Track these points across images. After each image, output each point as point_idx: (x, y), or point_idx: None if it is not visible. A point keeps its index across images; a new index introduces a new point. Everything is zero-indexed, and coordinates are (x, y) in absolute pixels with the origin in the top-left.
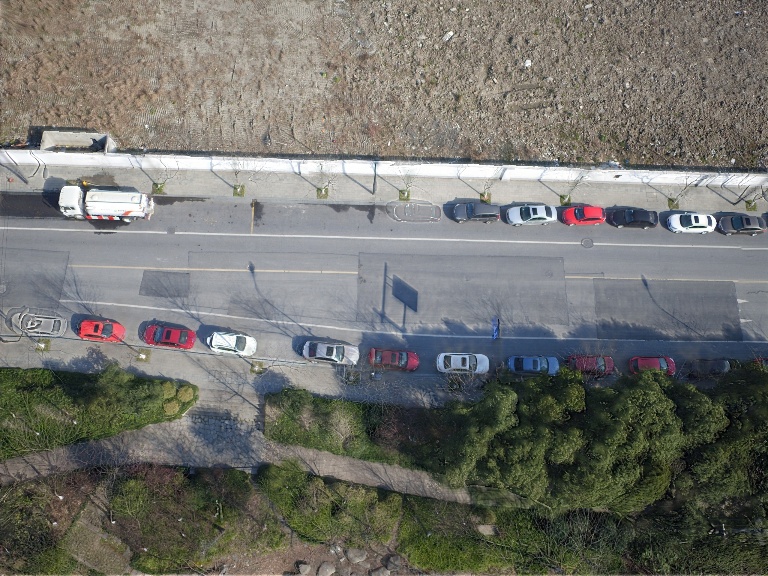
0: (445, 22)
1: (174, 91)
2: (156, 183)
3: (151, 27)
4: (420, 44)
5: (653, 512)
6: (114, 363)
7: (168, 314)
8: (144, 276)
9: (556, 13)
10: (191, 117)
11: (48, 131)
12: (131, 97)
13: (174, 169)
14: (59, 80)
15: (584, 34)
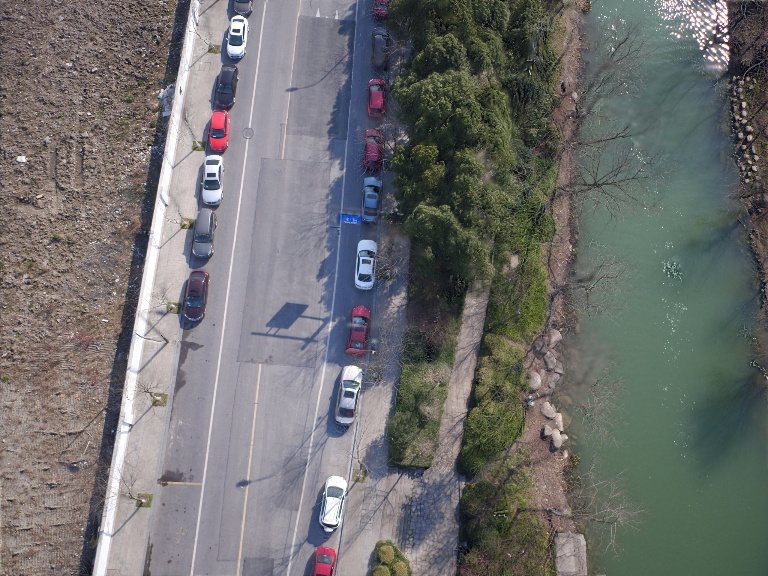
0: None
1: None
2: None
3: None
4: None
5: None
6: None
7: None
8: None
9: None
10: (30, 567)
11: None
12: None
13: None
14: None
15: None
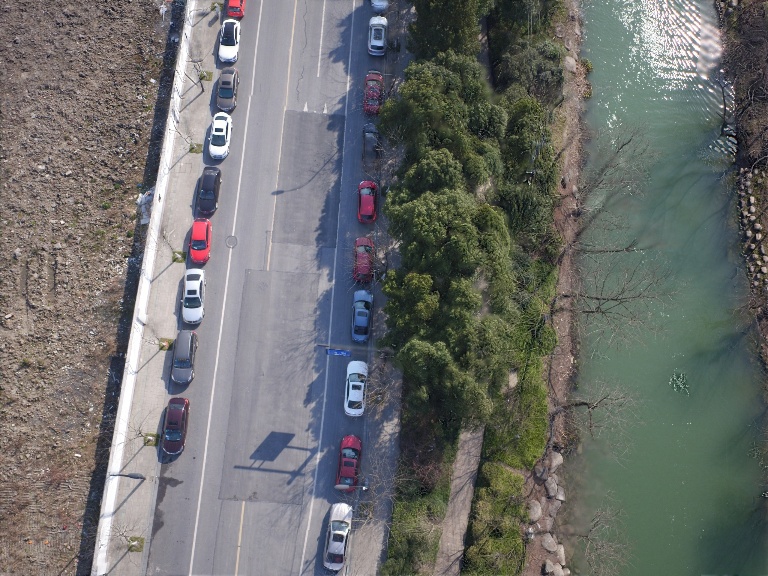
0: None
1: None
2: None
3: None
4: None
5: (511, 228)
6: None
7: None
8: None
9: None
10: None
11: None
12: None
13: None
14: None
15: None
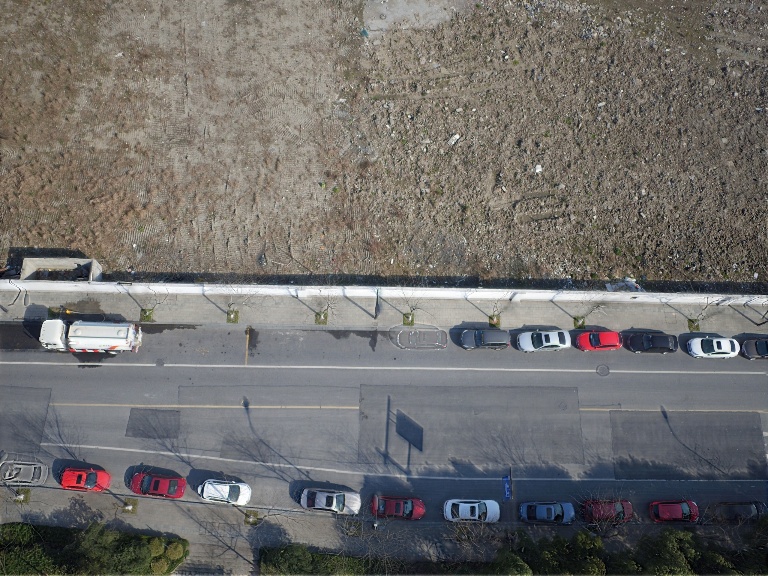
0: (451, 124)
1: (164, 206)
2: (144, 309)
3: (140, 134)
4: (424, 149)
5: None
6: (98, 515)
7: (156, 458)
8: (131, 415)
9: (567, 112)
10: (182, 235)
11: (29, 258)
12: (118, 213)
13: (164, 293)
14: (42, 196)
15: (597, 135)
